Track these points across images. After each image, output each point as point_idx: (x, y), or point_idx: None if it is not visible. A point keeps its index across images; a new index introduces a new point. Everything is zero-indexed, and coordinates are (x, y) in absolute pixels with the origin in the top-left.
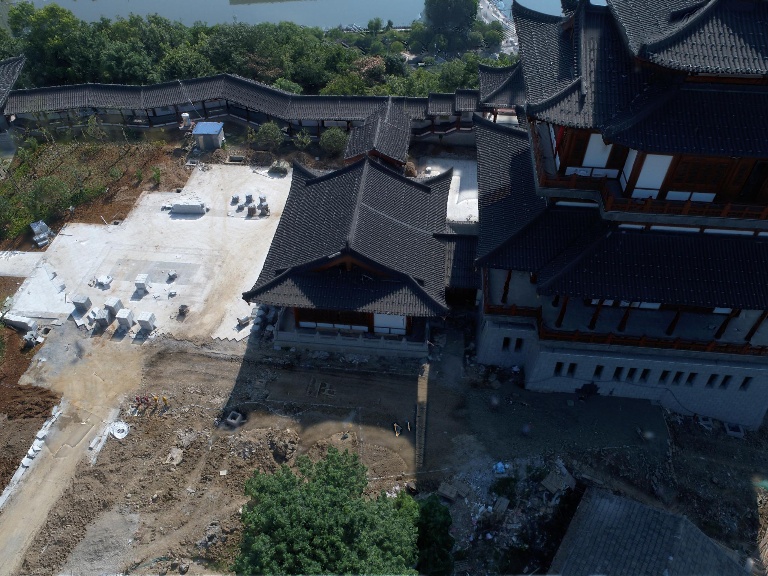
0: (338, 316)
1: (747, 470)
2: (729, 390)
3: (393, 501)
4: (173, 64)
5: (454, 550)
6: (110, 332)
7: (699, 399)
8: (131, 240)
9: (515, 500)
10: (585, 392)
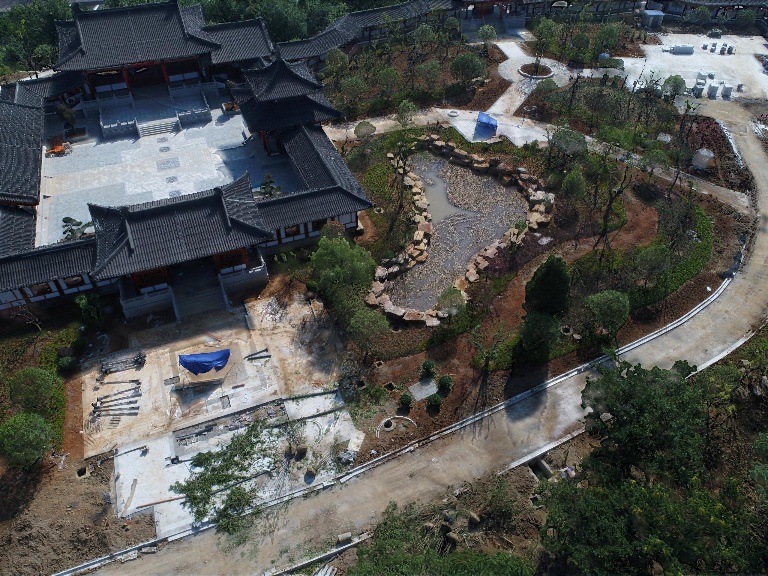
0: None
1: None
2: None
3: None
4: None
5: None
6: (706, 96)
7: None
8: (663, 63)
9: None
10: None
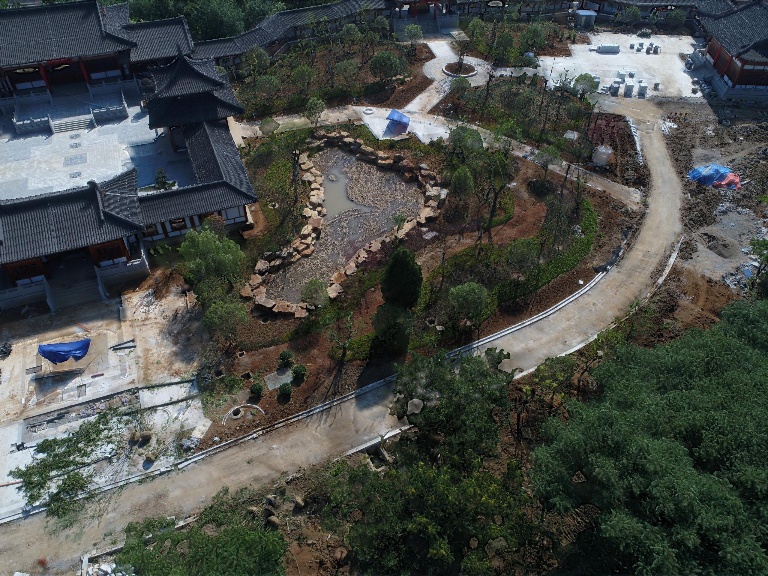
0: (762, 79)
1: None
2: None
3: None
4: None
5: None
6: (621, 95)
7: None
8: (587, 62)
9: None
10: None
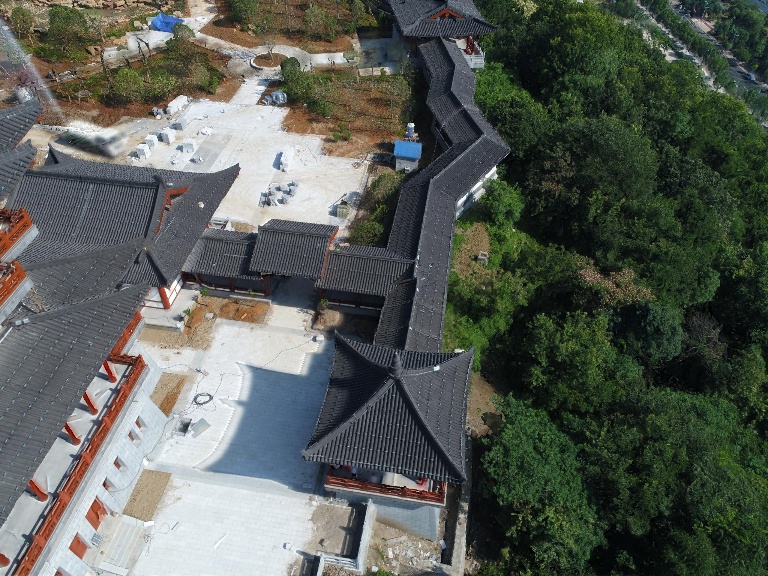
0: None
1: None
2: None
3: None
4: (502, 100)
5: None
6: None
7: None
8: (255, 137)
9: None
10: None
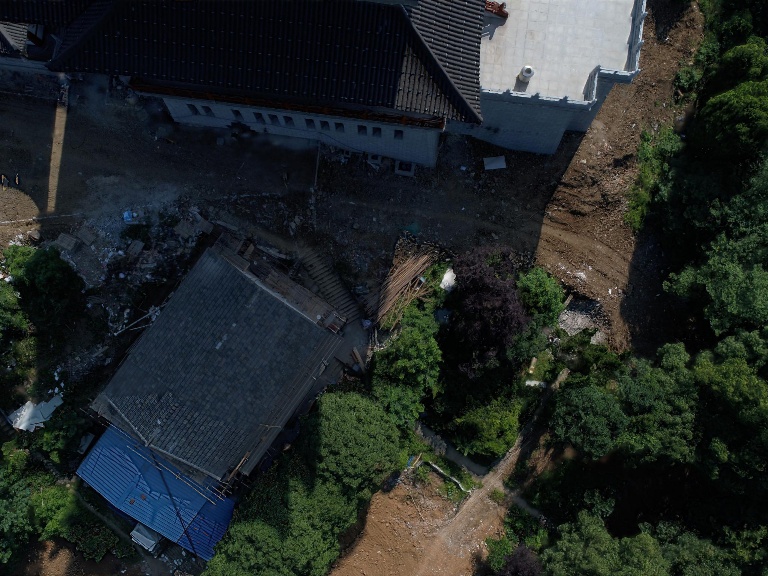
0: None
1: (399, 213)
2: (385, 138)
3: (10, 253)
4: None
5: (87, 288)
6: None
7: (359, 142)
8: None
9: (150, 243)
10: (239, 128)
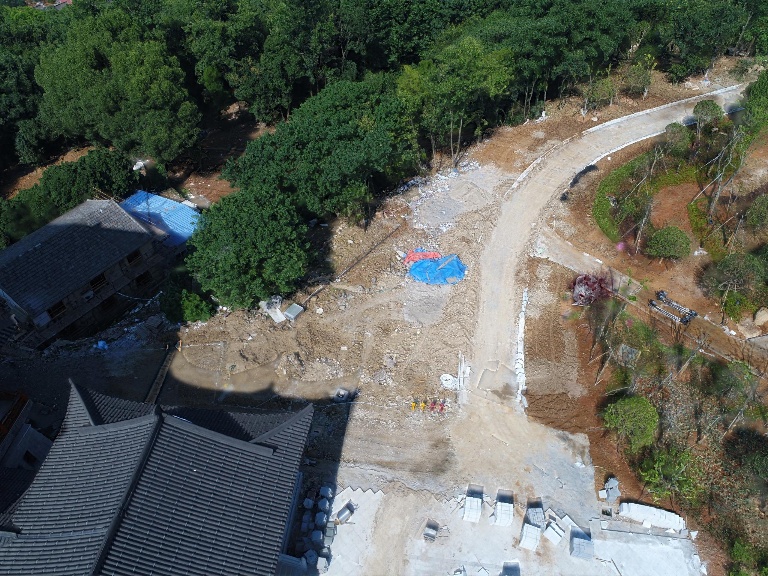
0: None
1: None
2: None
3: None
4: None
5: None
6: (519, 504)
7: None
8: None
9: None
10: None
